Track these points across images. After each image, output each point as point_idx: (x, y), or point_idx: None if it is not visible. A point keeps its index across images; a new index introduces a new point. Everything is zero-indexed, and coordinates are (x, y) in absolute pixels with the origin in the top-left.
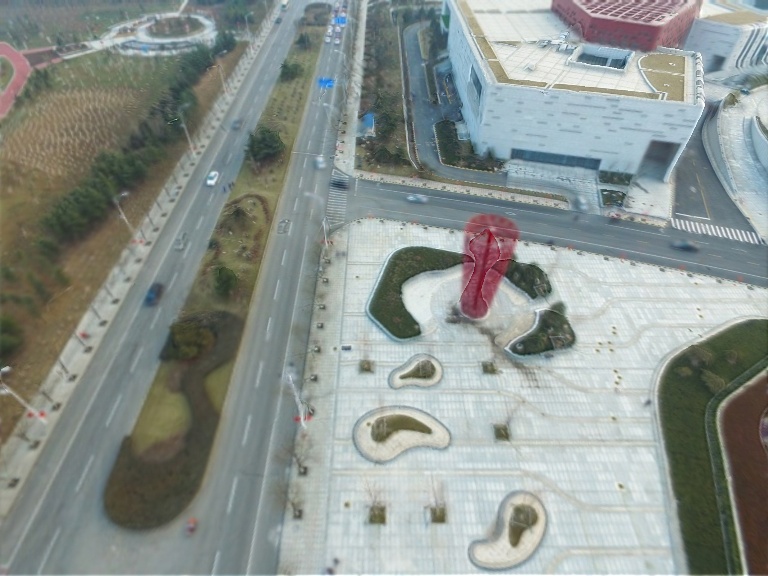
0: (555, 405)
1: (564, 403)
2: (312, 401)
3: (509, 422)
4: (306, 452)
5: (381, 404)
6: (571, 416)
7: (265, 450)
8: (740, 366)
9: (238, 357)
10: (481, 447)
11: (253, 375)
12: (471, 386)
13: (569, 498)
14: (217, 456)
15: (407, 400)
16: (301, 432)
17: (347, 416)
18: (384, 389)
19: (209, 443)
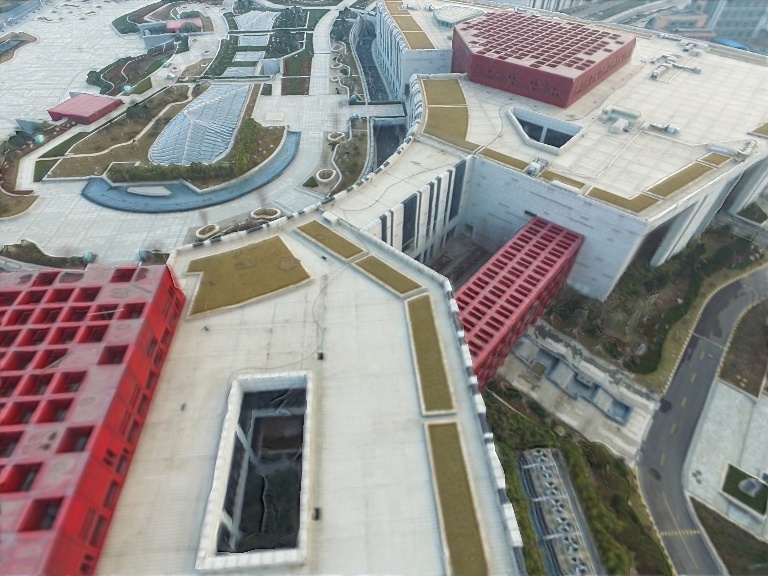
0: (119, 5)
1: (123, 5)
2: (47, 3)
3: (103, 6)
4: (41, 7)
5: (68, 4)
6: (122, 6)
7: (30, 8)
8: (182, 0)
9: (30, 0)
10: (91, 8)
11: (33, 2)
12: (98, 3)
13: (107, 12)
14: (17, 8)
15: (76, 4)
16: (41, 6)
17: (57, 5)
18: (71, 3)
19: (15, 7)
